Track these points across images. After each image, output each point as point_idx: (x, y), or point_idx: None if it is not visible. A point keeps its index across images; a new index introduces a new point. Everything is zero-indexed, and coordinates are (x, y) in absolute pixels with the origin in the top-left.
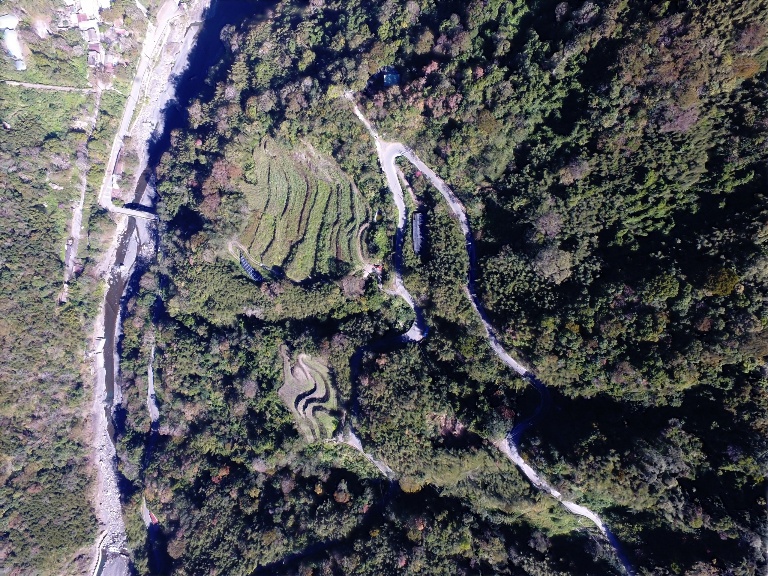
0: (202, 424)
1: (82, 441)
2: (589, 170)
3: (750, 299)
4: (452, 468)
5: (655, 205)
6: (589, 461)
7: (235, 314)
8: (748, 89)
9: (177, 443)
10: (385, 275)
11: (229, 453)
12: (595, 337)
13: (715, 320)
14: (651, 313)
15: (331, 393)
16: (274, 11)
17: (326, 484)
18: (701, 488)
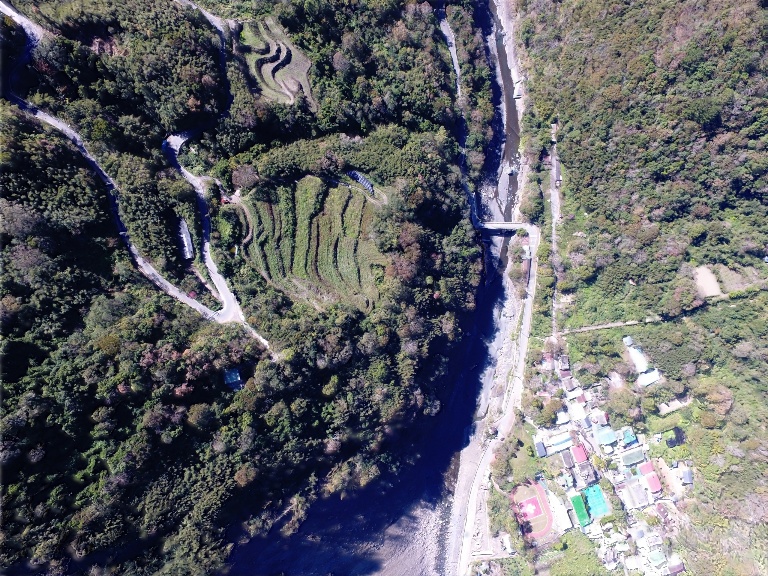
0: (388, 21)
1: None
2: None
3: None
4: (90, 1)
5: None
6: None
7: None
8: None
9: None
10: (215, 194)
11: None
12: None
13: None
14: None
15: (254, 70)
16: (384, 432)
17: None
18: None
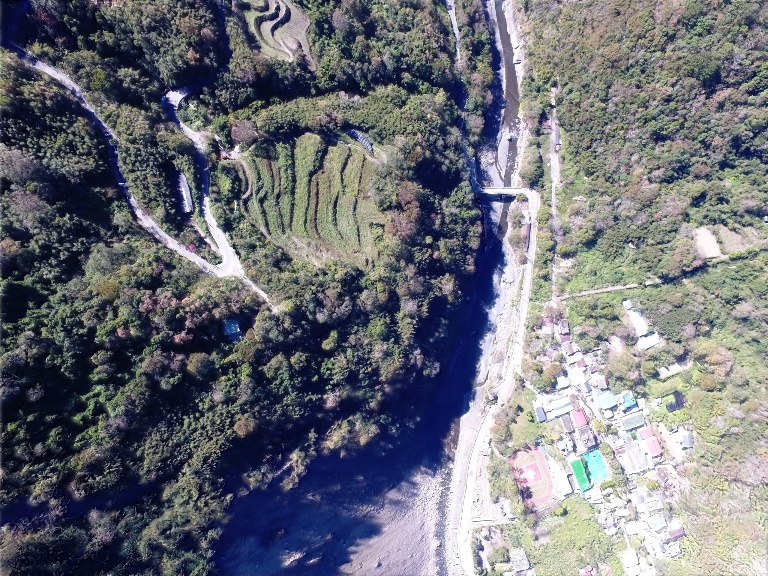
0: None
1: None
2: None
3: None
4: None
5: None
6: None
7: None
8: None
9: None
10: (214, 149)
11: None
12: None
13: None
14: None
15: (253, 27)
16: (384, 392)
17: None
18: None
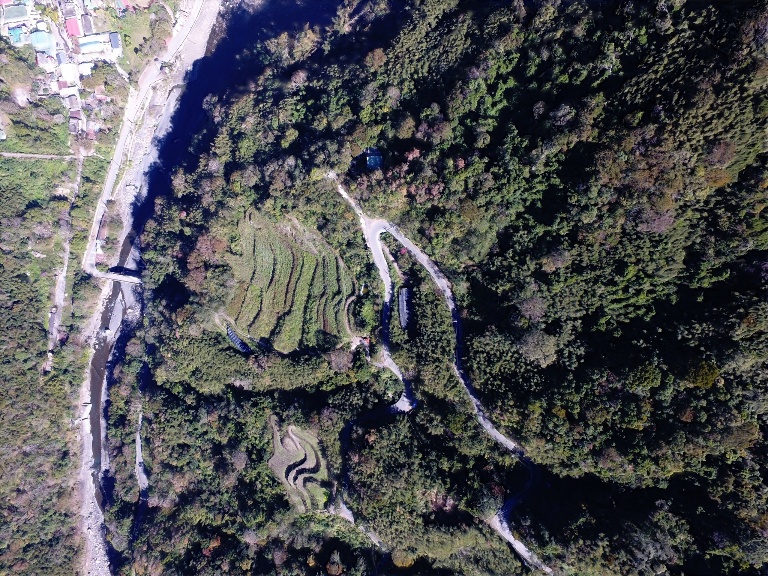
0: (192, 494)
1: (69, 510)
2: (570, 259)
3: (730, 393)
4: (444, 545)
5: (636, 295)
6: (579, 545)
7: (223, 384)
8: (721, 196)
9: (166, 514)
10: (373, 348)
11: (220, 524)
12: (581, 423)
13: (697, 412)
14: (635, 401)
15: (321, 463)
16: (256, 84)
17: (318, 554)
18: (689, 571)
